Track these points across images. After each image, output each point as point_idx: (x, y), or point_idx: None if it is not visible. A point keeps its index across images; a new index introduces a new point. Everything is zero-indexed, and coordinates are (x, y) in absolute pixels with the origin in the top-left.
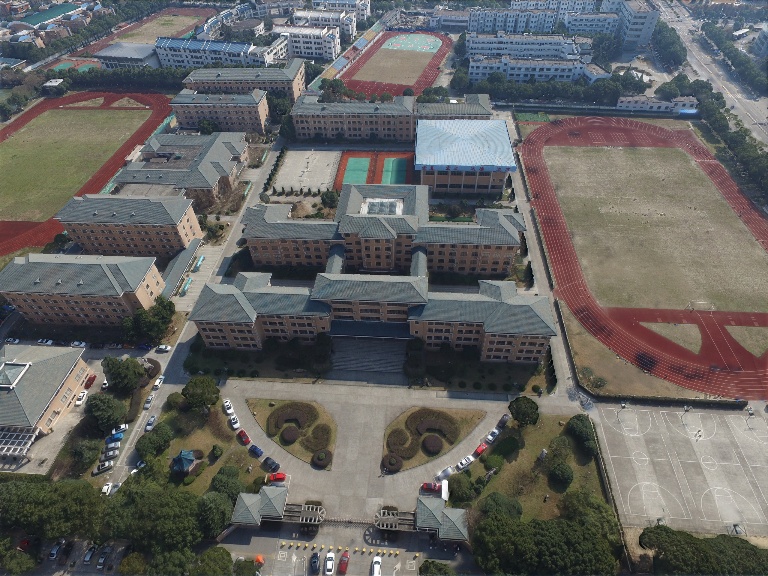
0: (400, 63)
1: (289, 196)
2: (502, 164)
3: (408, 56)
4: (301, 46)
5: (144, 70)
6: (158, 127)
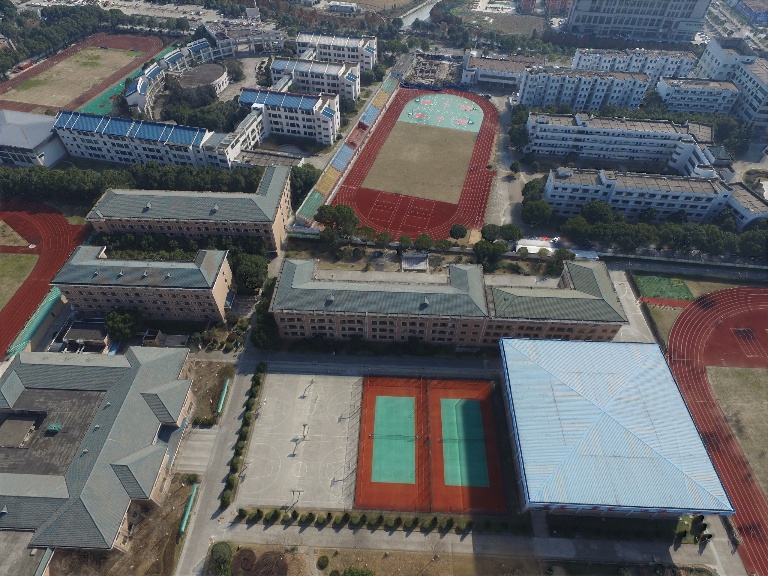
0: (430, 154)
1: (271, 526)
2: (704, 503)
3: (440, 139)
4: (282, 122)
5: (30, 175)
6: (40, 304)
